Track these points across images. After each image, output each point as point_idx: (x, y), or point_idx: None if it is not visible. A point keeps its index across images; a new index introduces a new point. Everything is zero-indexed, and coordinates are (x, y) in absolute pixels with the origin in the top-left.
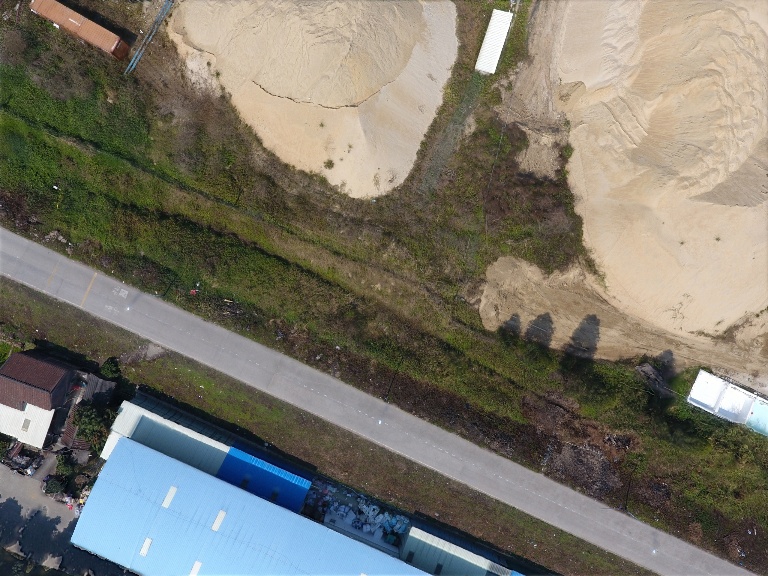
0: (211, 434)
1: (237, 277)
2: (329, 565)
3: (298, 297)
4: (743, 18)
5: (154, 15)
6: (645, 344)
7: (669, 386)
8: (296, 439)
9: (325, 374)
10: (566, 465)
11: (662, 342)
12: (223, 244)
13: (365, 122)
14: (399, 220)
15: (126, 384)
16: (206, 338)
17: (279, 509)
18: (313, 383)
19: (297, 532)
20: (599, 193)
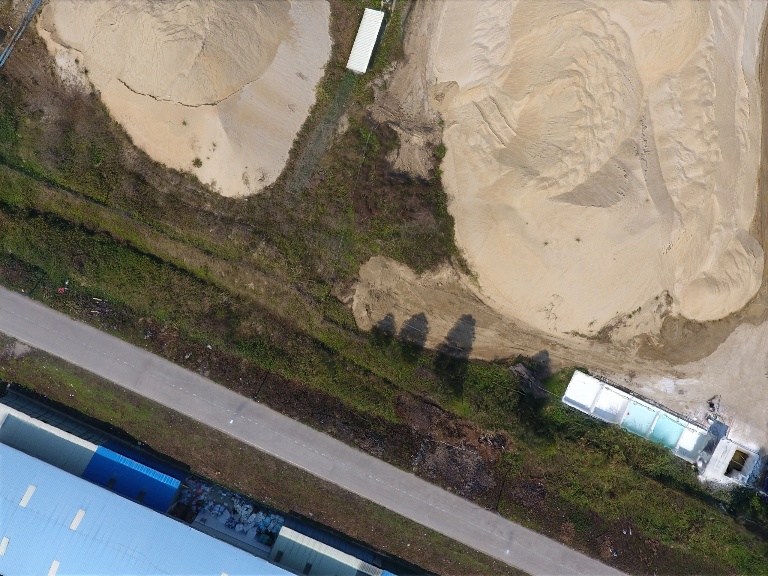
0: (82, 433)
1: (106, 275)
2: (189, 564)
3: (168, 296)
4: (604, 19)
5: (24, 12)
6: (521, 344)
7: (544, 386)
8: (167, 438)
9: (194, 373)
10: (439, 465)
11: (538, 342)
12: (94, 242)
13: (226, 120)
14: (271, 219)
15: None
16: (73, 337)
17: (141, 508)
18: (182, 382)
19: (158, 531)
20: (469, 193)
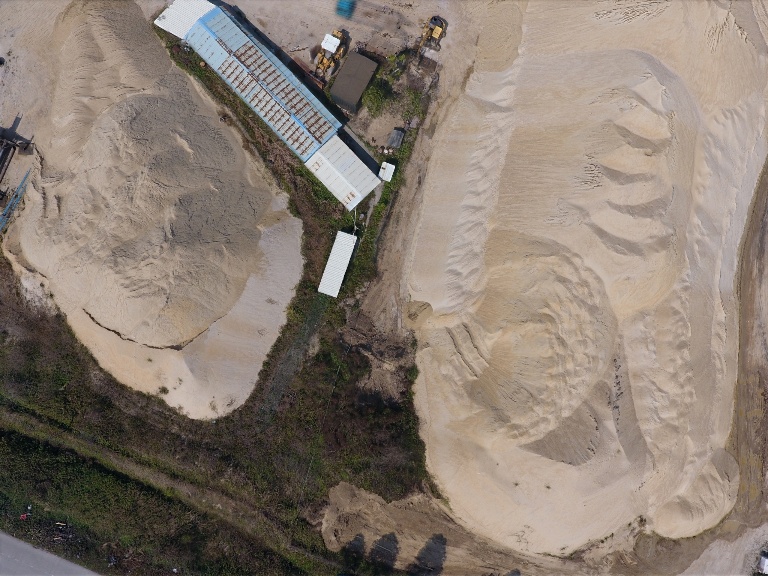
0: None
1: (70, 501)
2: None
3: (133, 521)
4: (578, 264)
5: None
6: (492, 563)
7: None
8: None
9: None
10: None
11: (509, 561)
12: (58, 464)
13: (192, 361)
14: (239, 442)
15: None
16: (35, 565)
17: None
18: None
19: None
20: (440, 422)
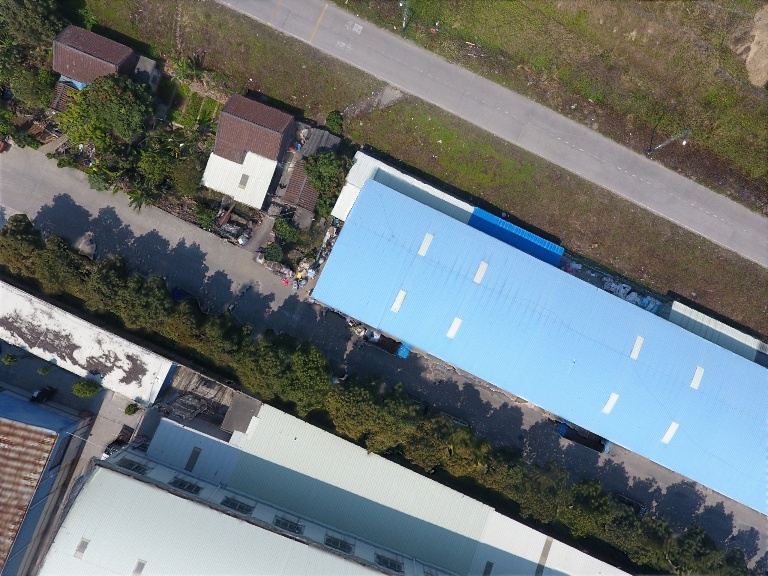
0: None
1: (482, 15)
2: (603, 325)
3: (549, 40)
4: None
5: None
6: None
7: None
8: (543, 203)
9: (581, 125)
10: None
11: None
12: None
13: None
14: None
15: (347, 146)
16: (449, 81)
17: (544, 264)
18: (568, 135)
19: (565, 289)
20: None
